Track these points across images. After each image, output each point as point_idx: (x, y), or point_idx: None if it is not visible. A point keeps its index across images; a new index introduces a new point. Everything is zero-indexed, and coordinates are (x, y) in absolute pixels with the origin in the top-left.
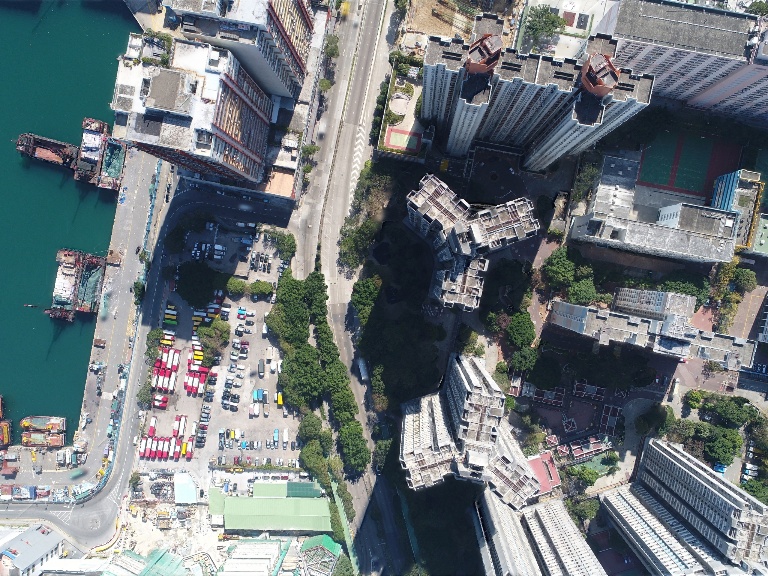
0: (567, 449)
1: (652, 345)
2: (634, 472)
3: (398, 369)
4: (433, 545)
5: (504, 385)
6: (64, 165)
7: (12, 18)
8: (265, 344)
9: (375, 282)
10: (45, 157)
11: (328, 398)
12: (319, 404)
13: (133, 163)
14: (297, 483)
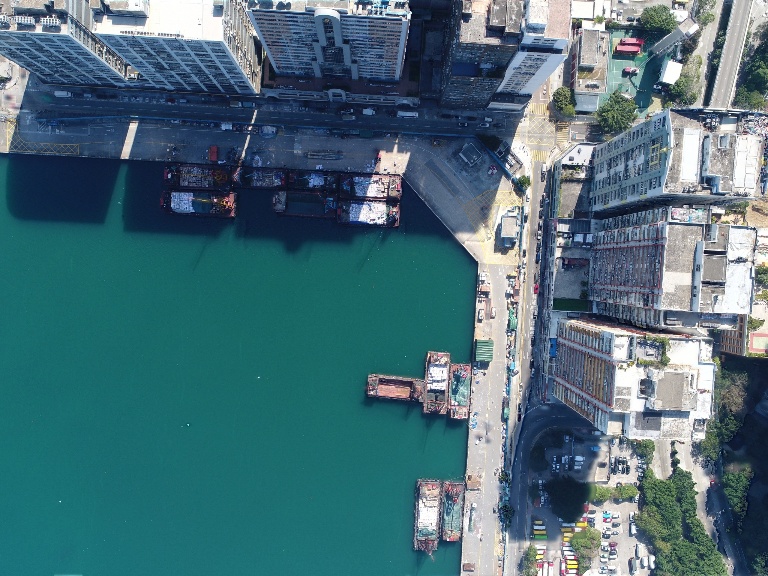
0: None
1: None
2: None
3: None
4: None
5: None
6: (412, 400)
7: (336, 261)
8: (632, 542)
9: (747, 475)
10: (388, 393)
11: None
12: None
13: (480, 388)
14: None
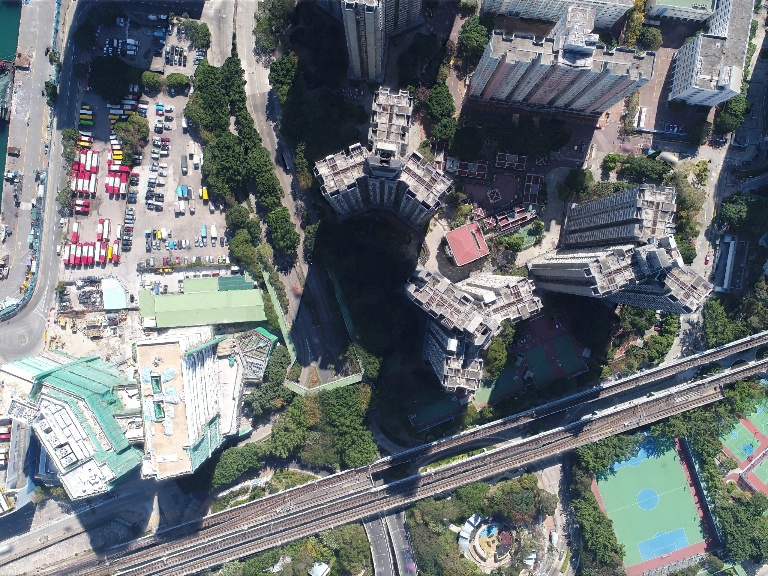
0: (493, 221)
1: (558, 66)
2: (560, 241)
3: (320, 145)
4: (367, 320)
5: (426, 155)
6: None
7: None
8: (186, 140)
9: (291, 59)
10: None
11: (254, 190)
12: (245, 197)
13: None
14: (228, 277)
